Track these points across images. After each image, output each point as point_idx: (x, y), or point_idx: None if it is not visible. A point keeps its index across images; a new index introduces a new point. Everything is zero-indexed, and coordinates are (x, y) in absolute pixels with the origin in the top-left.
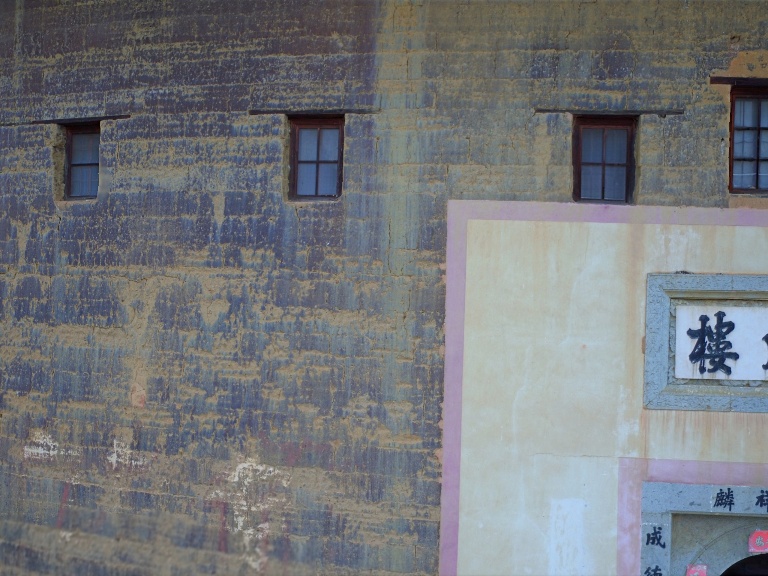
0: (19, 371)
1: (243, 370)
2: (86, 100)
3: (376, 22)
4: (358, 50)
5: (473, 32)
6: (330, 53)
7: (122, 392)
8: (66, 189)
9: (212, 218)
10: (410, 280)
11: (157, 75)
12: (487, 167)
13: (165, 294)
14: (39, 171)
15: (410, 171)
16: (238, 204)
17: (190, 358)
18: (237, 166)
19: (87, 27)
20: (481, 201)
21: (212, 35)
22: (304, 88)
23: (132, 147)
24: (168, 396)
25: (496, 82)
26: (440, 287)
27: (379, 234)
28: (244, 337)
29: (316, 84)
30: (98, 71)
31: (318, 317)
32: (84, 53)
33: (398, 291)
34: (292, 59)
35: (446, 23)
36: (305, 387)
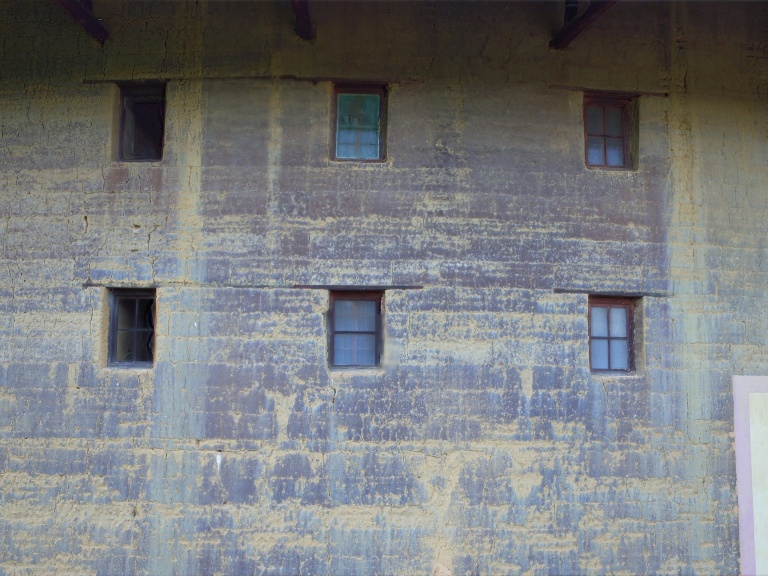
0: (281, 560)
1: (559, 542)
2: (368, 267)
3: (666, 216)
4: (652, 240)
5: (742, 231)
6: (628, 241)
7: (422, 574)
8: (329, 357)
9: (520, 392)
10: (706, 448)
11: (454, 248)
12: (759, 347)
13: (470, 469)
14: (306, 339)
15: (701, 350)
16: (547, 378)
17: (502, 533)
18: (544, 342)
19: (366, 193)
20: (758, 376)
21: (512, 214)
22: (606, 271)
23: (427, 319)
24: (478, 575)
25: (762, 275)
26: (731, 453)
27: (679, 406)
28: (559, 509)
29: (617, 268)
30: (382, 239)
31: (630, 486)
32: (363, 219)
33: (698, 458)
34: (593, 244)
35: (721, 222)
36: (621, 554)
